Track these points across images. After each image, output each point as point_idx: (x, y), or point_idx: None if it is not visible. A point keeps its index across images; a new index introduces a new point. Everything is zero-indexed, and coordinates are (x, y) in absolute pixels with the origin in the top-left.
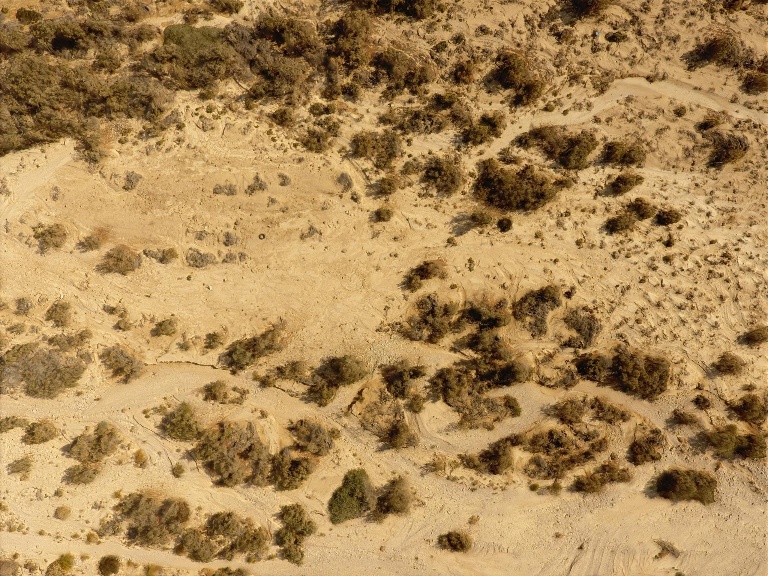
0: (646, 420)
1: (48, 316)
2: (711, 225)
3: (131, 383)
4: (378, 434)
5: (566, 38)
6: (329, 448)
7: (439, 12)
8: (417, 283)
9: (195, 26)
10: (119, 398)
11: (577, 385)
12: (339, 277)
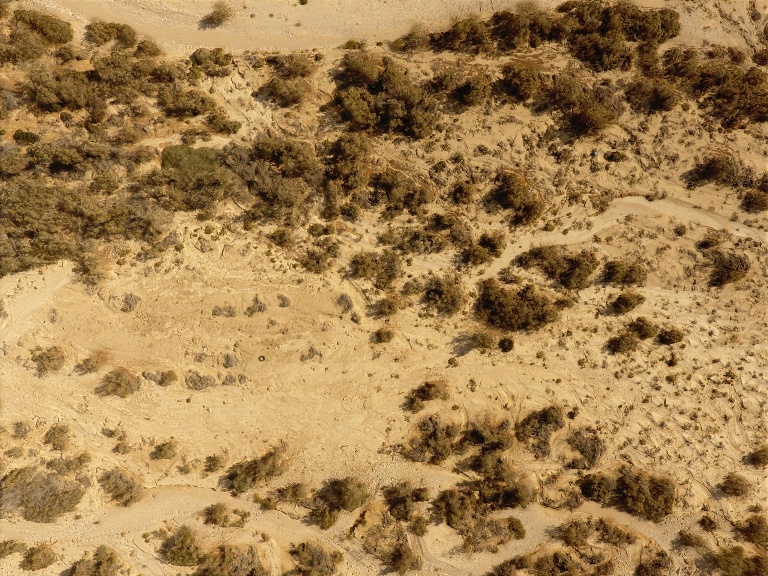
0: (652, 542)
1: (46, 441)
2: (713, 344)
3: (130, 506)
4: (381, 558)
5: (565, 158)
6: (331, 573)
7: (437, 132)
8: (419, 406)
9: (193, 147)
10: (118, 521)
11: (581, 506)
12: (340, 398)
